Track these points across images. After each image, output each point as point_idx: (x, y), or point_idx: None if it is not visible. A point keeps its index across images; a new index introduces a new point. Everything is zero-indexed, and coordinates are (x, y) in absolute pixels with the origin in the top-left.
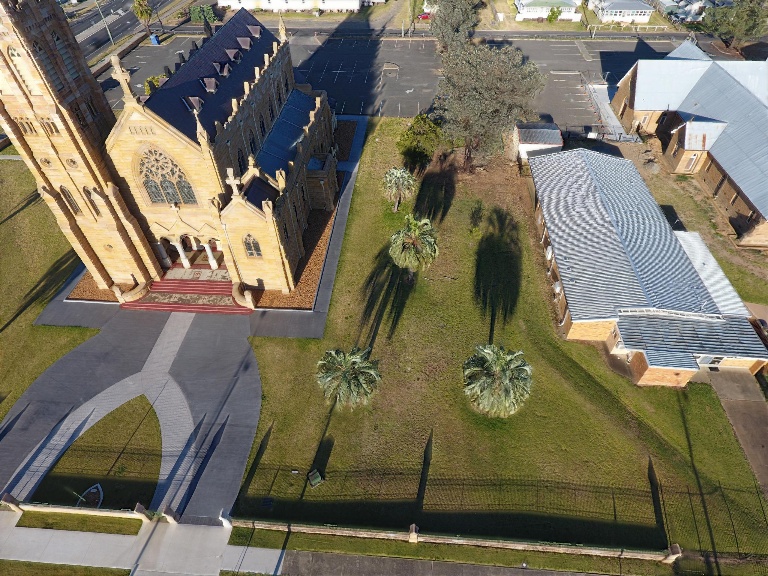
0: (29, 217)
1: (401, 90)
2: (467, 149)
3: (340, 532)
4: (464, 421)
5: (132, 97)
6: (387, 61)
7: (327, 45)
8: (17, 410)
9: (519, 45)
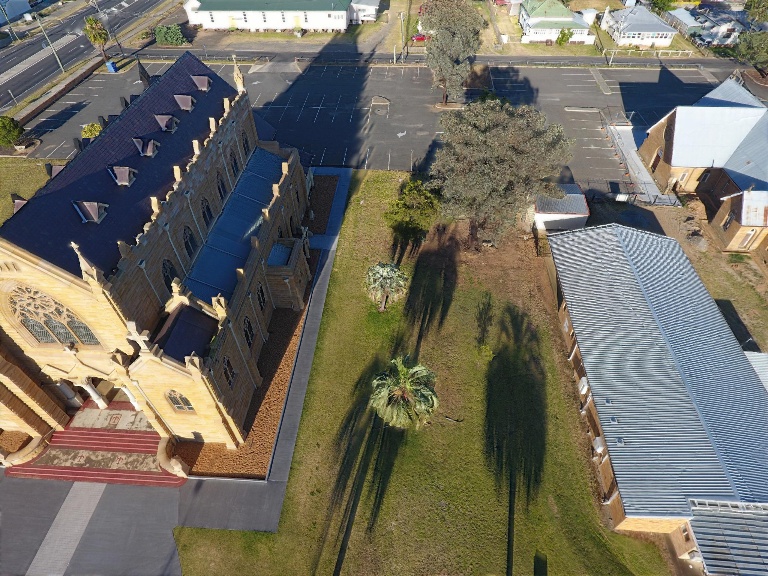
0: None
1: (392, 133)
2: None
3: None
4: None
5: None
6: (376, 94)
7: (308, 73)
8: None
9: (527, 74)
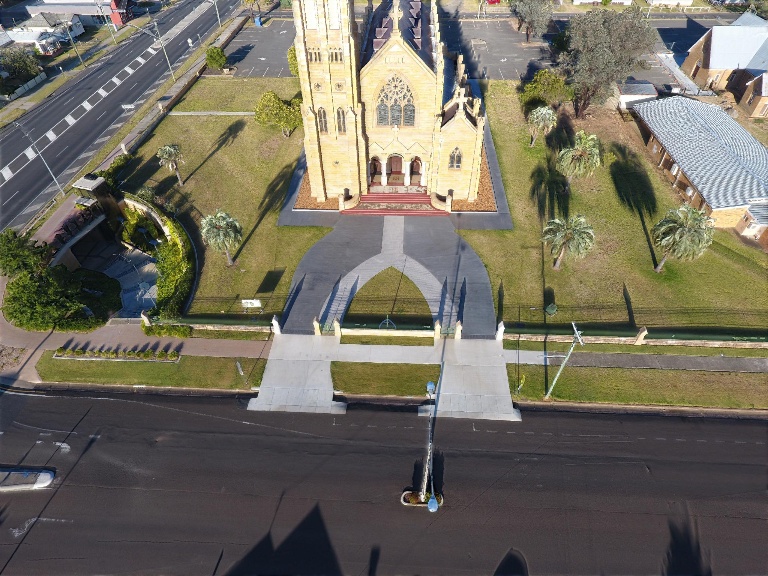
0: (227, 155)
1: (496, 59)
2: (572, 102)
3: (584, 339)
4: (646, 277)
5: (398, 32)
6: (473, 37)
7: None
8: (298, 278)
9: None
